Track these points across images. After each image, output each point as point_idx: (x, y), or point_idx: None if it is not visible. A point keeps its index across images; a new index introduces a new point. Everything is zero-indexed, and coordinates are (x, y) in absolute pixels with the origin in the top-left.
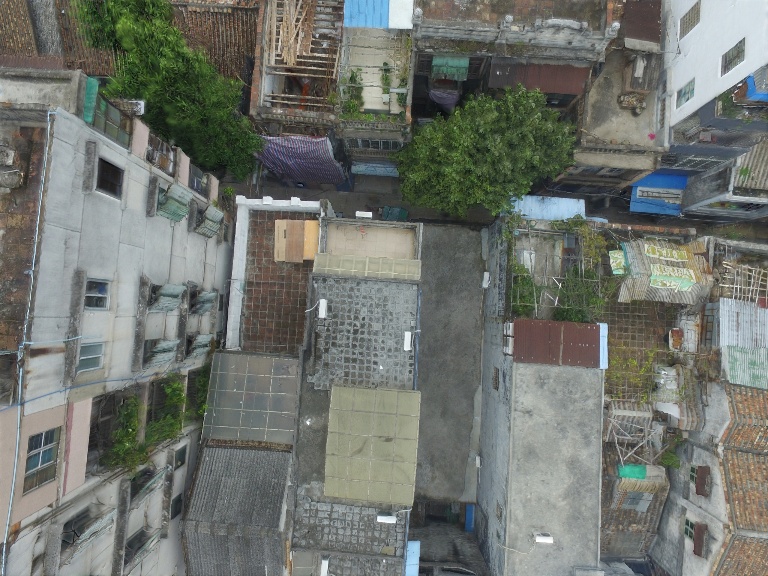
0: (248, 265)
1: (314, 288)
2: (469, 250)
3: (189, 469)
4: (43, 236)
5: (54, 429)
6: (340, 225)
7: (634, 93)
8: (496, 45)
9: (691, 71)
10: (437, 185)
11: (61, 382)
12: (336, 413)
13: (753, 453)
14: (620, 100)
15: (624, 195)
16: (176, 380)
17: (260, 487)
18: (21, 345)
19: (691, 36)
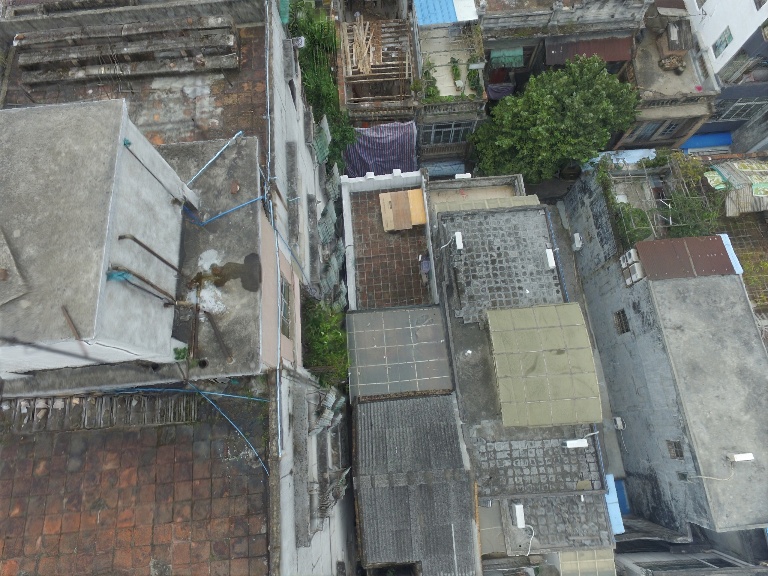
0: (356, 243)
1: (444, 228)
2: None
3: None
4: (274, 90)
5: (285, 286)
6: (440, 191)
7: (673, 55)
8: (549, 27)
9: (722, 23)
10: (520, 150)
11: (287, 239)
12: (498, 335)
13: None
14: (662, 63)
15: None
16: None
17: (430, 432)
18: None
19: None
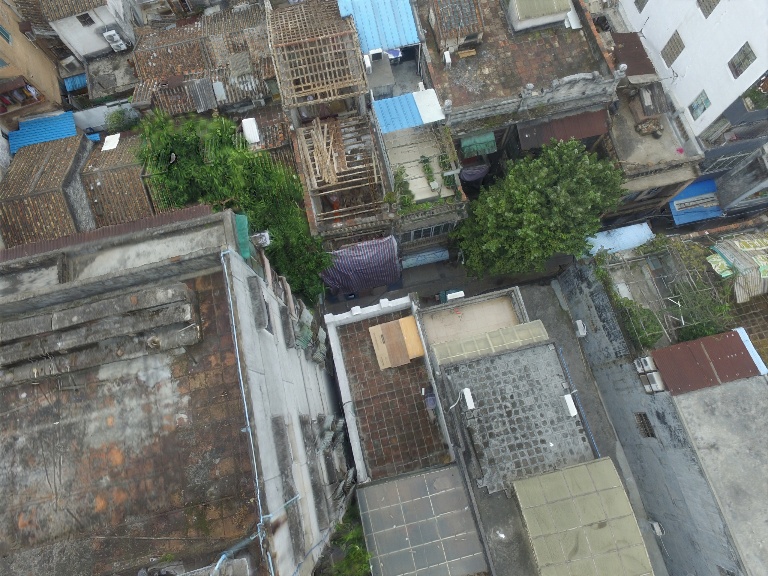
0: (351, 384)
1: (449, 381)
2: (547, 306)
3: None
4: (249, 384)
5: None
6: (434, 314)
7: (649, 119)
8: (519, 113)
9: (697, 86)
10: (509, 249)
11: (292, 560)
12: (531, 512)
13: None
14: (639, 129)
15: (664, 212)
16: (345, 531)
17: None
18: (258, 522)
19: (681, 60)
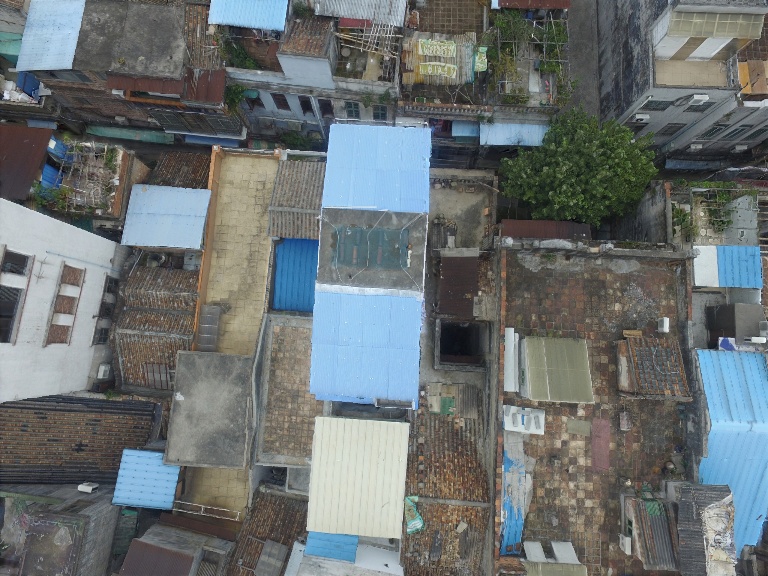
0: None
1: None
2: None
3: None
4: None
5: None
6: None
7: None
8: None
9: None
10: None
11: None
12: None
13: None
14: None
15: None
16: None
17: None
18: None
19: None
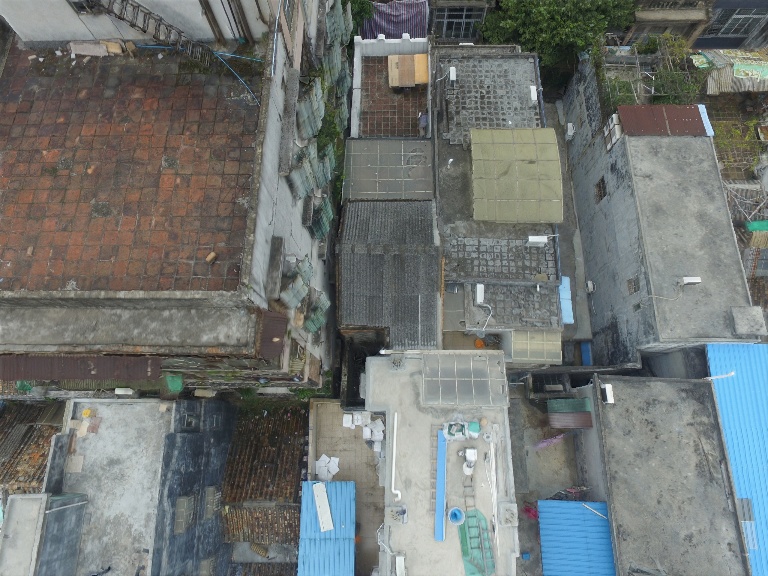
0: (362, 99)
1: (441, 67)
2: (547, 118)
3: (329, 233)
4: None
5: (291, 1)
6: None
7: None
8: None
9: None
10: (523, 34)
11: None
12: (478, 146)
13: None
14: None
15: None
16: None
17: (408, 222)
18: None
19: None
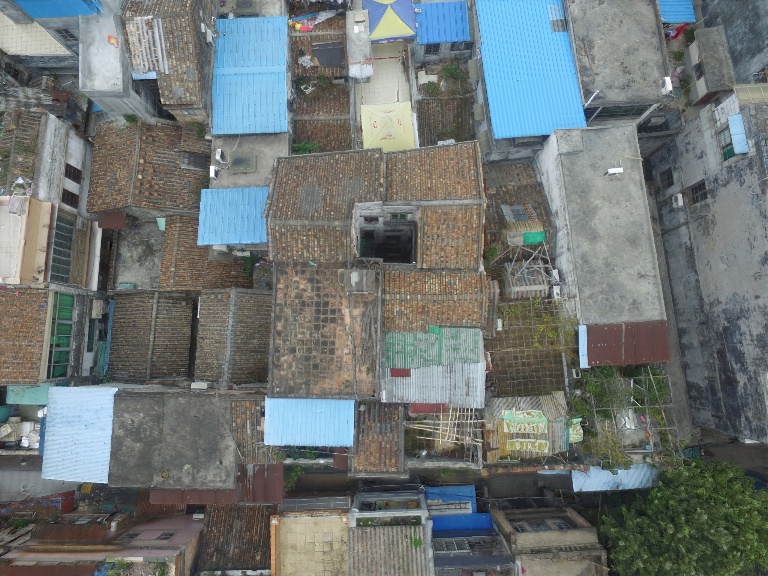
0: None
1: None
2: None
3: None
4: None
5: None
6: None
7: None
8: None
9: None
10: None
11: None
12: None
13: (450, 269)
14: None
15: None
16: None
17: None
18: None
19: None
